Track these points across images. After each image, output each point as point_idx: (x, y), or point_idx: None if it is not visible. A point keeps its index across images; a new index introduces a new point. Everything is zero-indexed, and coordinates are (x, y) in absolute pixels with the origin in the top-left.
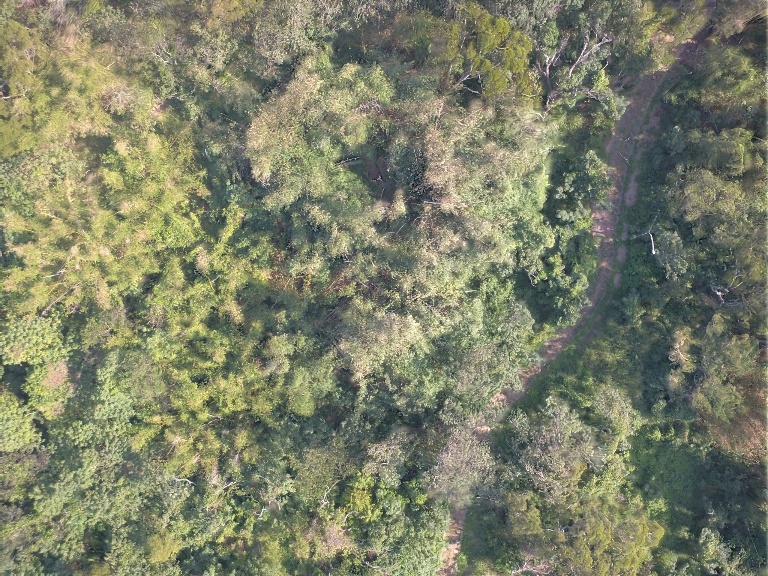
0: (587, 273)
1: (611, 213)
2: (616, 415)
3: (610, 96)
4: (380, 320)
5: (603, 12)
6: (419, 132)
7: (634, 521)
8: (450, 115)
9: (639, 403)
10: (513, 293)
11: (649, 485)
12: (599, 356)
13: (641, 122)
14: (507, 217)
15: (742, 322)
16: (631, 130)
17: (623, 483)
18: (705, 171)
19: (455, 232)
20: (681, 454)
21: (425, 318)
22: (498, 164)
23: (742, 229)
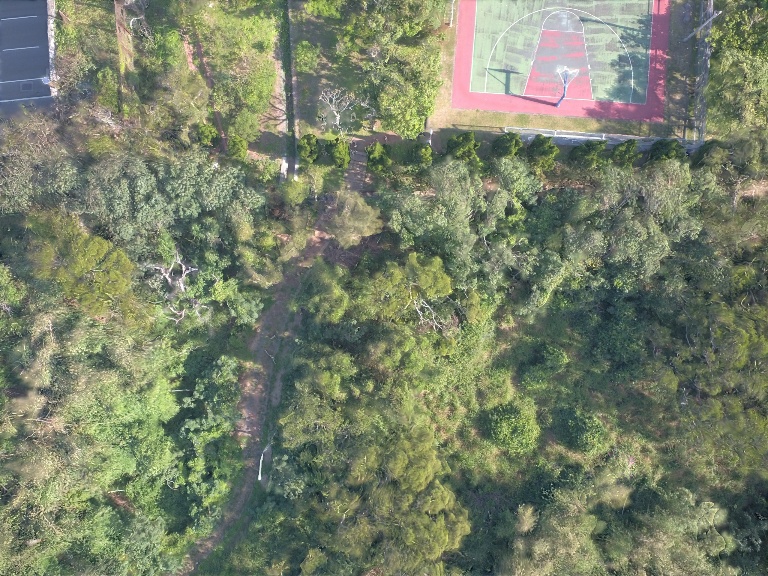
0: (228, 477)
1: (258, 412)
2: None
3: (238, 302)
4: (5, 533)
5: (210, 227)
6: (39, 342)
7: None
8: (66, 327)
9: None
10: (161, 492)
11: None
12: (240, 562)
13: (286, 319)
14: (122, 434)
15: (343, 554)
16: (276, 327)
17: None
18: (308, 397)
19: (67, 452)
20: None
21: (46, 534)
22: (108, 383)
23: (376, 438)
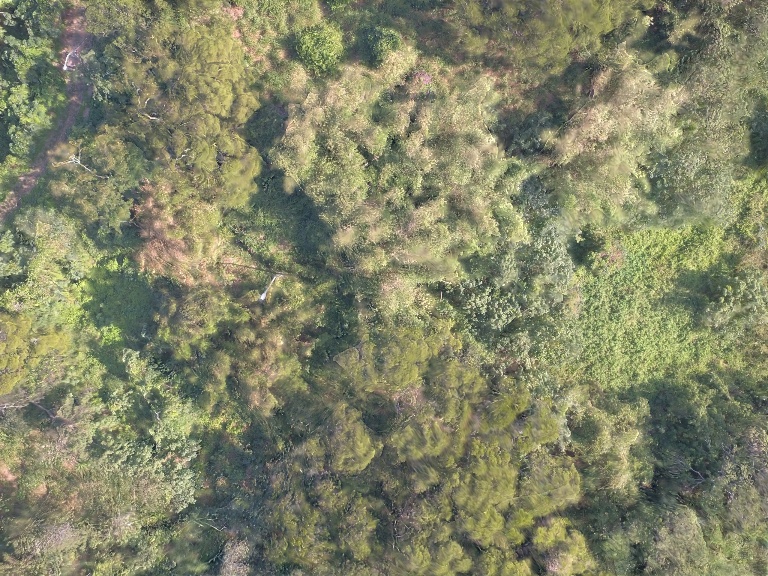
0: (49, 104)
1: (83, 48)
2: (43, 234)
3: None
4: None
5: None
6: None
7: (6, 322)
8: None
9: (93, 232)
10: None
11: (102, 314)
12: (58, 186)
13: None
14: None
15: (139, 135)
16: None
17: (82, 313)
18: None
19: None
20: (138, 285)
21: None
22: None
23: None
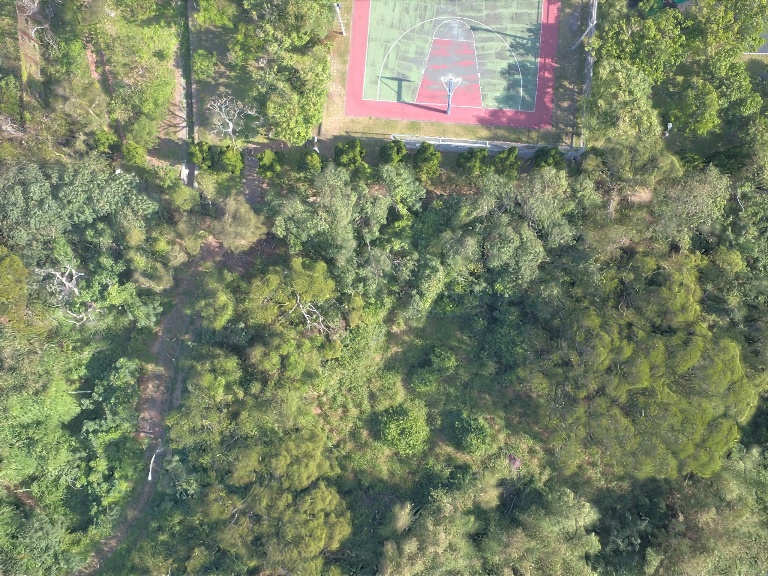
0: (128, 477)
1: (159, 413)
2: None
3: (135, 306)
4: None
5: (102, 232)
6: None
7: None
8: None
9: None
10: (66, 492)
11: None
12: (141, 560)
13: (187, 322)
14: (19, 435)
15: (229, 552)
16: (177, 330)
17: None
18: (196, 399)
19: None
20: None
21: None
22: (4, 384)
23: (271, 439)
